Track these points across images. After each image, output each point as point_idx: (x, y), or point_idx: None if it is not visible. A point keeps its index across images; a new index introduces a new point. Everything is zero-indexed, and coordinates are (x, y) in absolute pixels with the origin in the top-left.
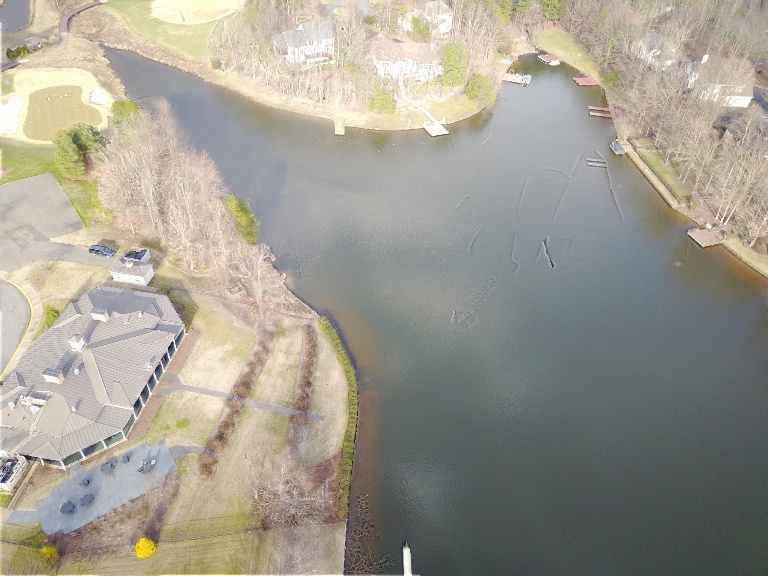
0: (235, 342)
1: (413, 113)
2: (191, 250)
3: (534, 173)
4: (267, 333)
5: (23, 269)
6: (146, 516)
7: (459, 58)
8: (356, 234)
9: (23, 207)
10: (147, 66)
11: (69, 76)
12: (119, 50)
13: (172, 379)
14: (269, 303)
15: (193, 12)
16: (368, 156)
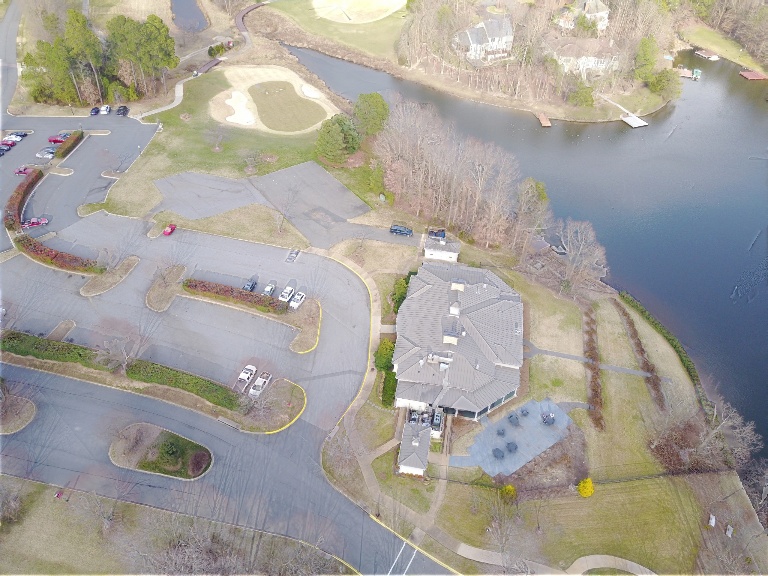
0: (563, 312)
1: (605, 106)
2: (501, 228)
3: (745, 161)
4: (584, 305)
5: (338, 247)
6: (570, 461)
7: (651, 53)
8: (624, 216)
9: (307, 191)
10: (333, 63)
11: (273, 72)
12: (300, 48)
13: (527, 344)
14: (588, 277)
15: (356, 12)
16: (557, 147)
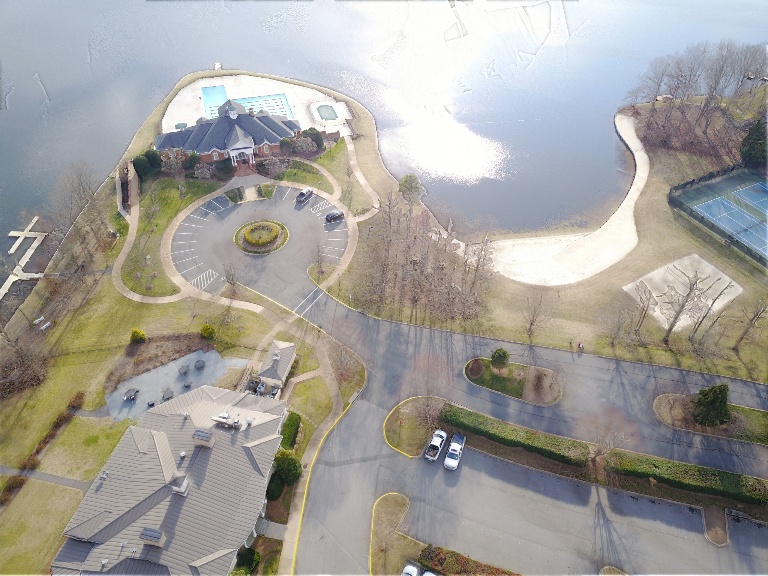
0: None
1: None
2: None
3: None
4: None
5: None
6: None
7: None
8: None
9: None
10: None
11: None
12: None
13: None
14: None
15: None
16: None
